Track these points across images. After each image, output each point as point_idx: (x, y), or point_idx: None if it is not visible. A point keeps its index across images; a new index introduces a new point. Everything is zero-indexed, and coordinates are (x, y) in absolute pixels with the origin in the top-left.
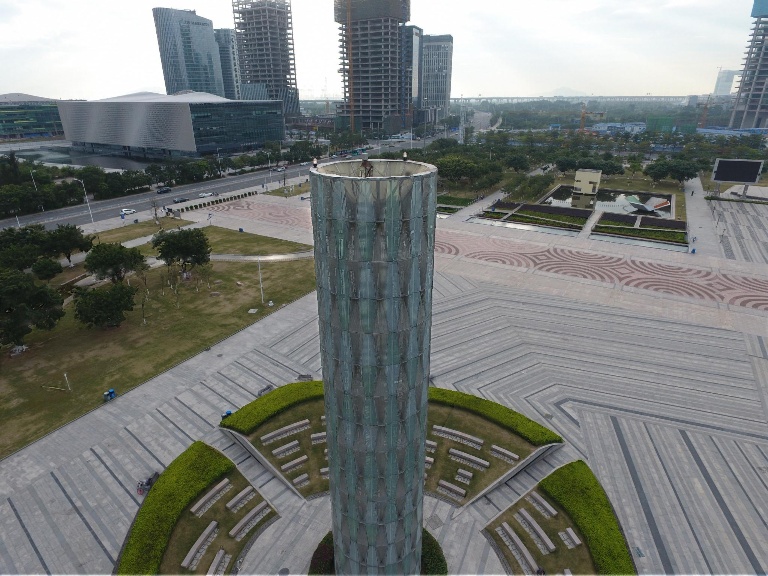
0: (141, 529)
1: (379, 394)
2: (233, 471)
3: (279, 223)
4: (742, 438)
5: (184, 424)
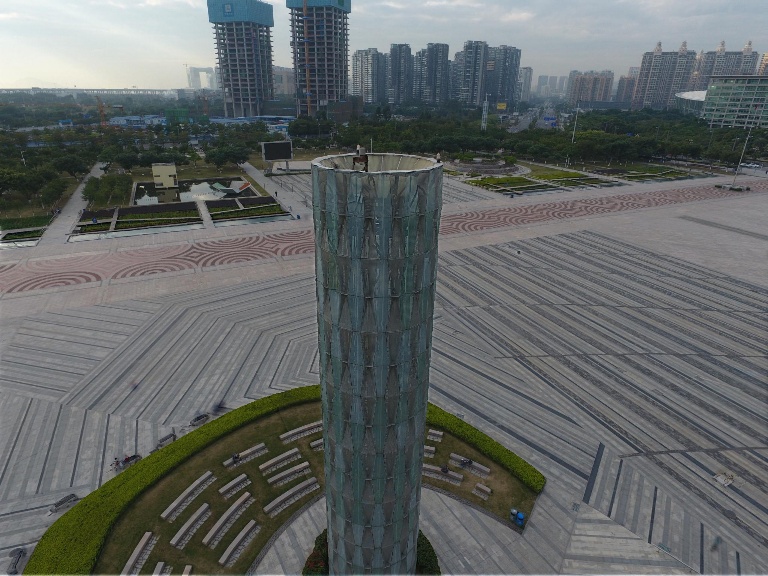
0: None
1: (424, 377)
2: None
3: None
4: None
5: None
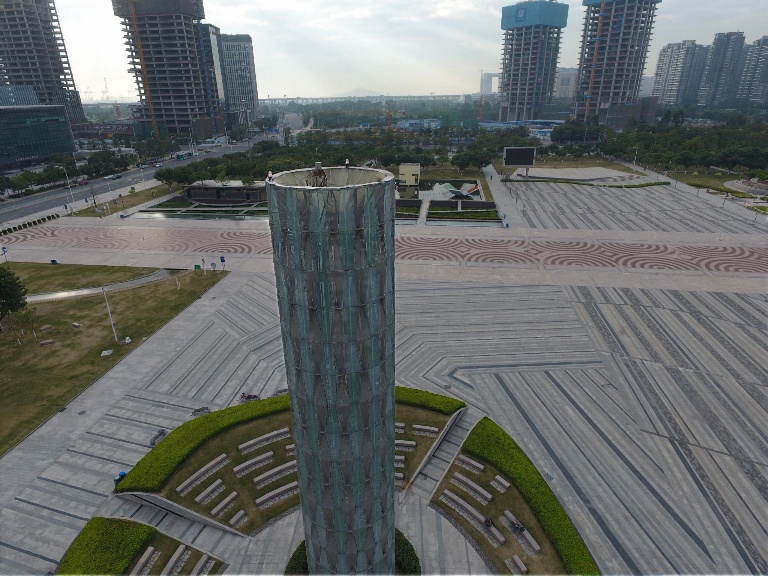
0: None
1: (363, 398)
2: (155, 536)
3: (102, 248)
4: (585, 366)
5: (64, 504)
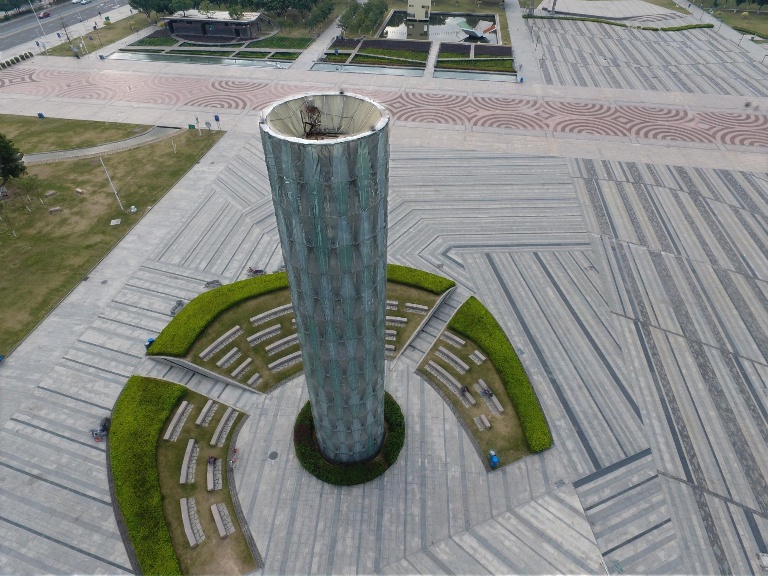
0: (123, 470)
1: (357, 316)
2: (187, 393)
3: (88, 98)
4: (573, 248)
5: (106, 364)
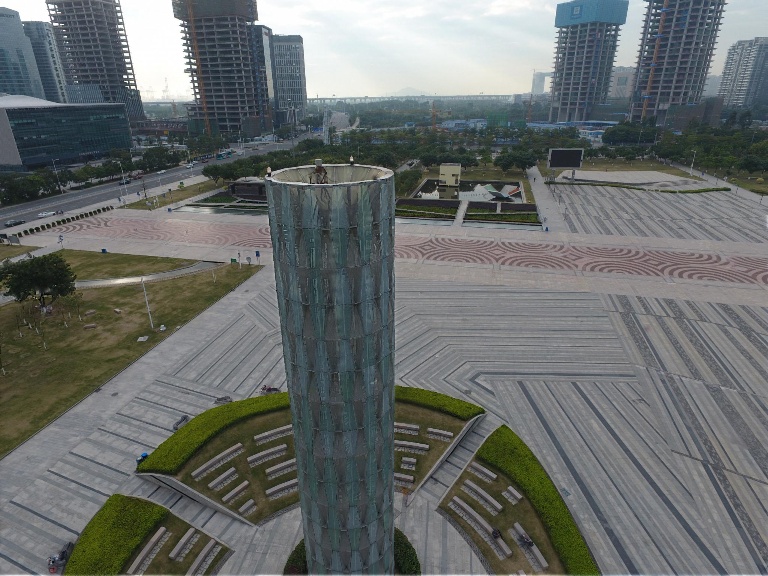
0: None
1: (357, 398)
2: (168, 517)
3: (149, 239)
4: (616, 379)
5: (90, 480)
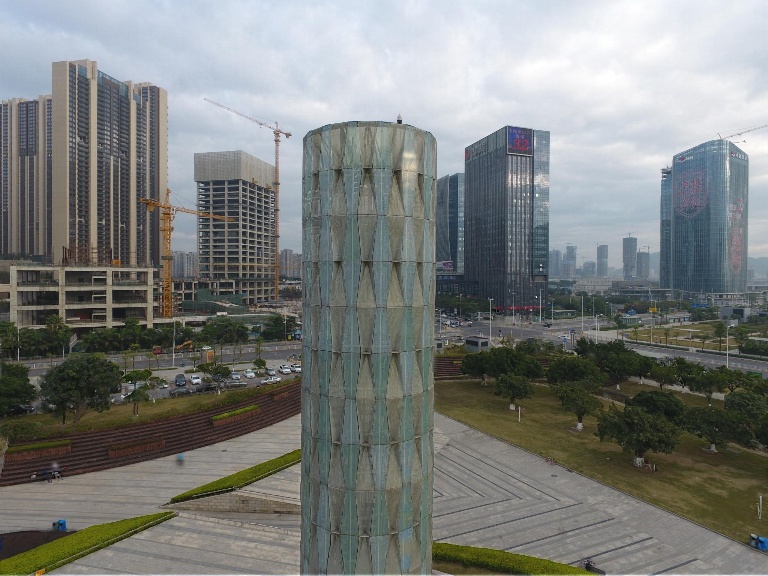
0: None
1: None
2: None
3: None
4: None
5: None
